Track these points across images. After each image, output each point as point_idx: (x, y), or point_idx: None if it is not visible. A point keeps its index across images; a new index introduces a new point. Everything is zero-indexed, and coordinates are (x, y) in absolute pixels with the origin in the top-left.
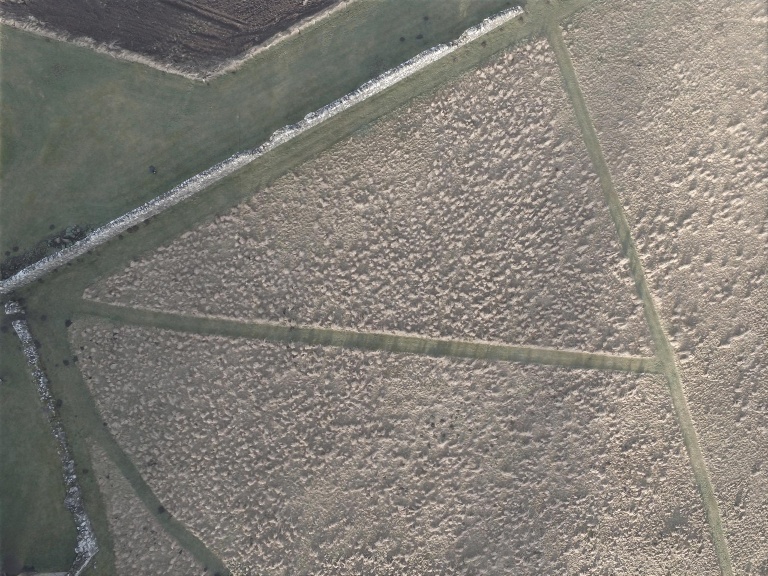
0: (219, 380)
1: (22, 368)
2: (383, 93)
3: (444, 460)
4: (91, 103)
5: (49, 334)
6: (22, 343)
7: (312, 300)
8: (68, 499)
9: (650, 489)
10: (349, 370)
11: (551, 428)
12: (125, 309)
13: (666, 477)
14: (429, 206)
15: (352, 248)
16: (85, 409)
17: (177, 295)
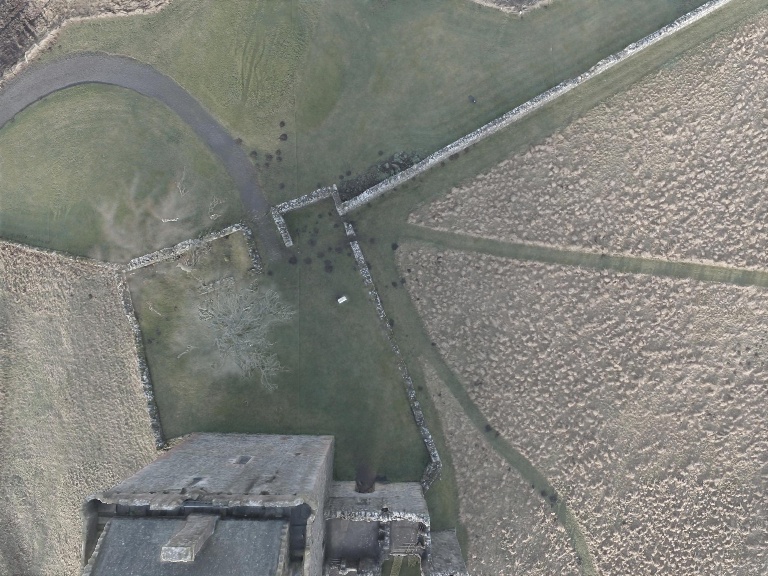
0: (538, 304)
1: (358, 287)
2: (687, 28)
3: (750, 387)
4: (413, 34)
5: (377, 256)
6: (358, 263)
7: (622, 229)
8: (418, 411)
9: None
10: (659, 297)
11: None
12: (447, 234)
13: None
14: (732, 139)
15: (660, 179)
16: (414, 329)
17: (495, 221)
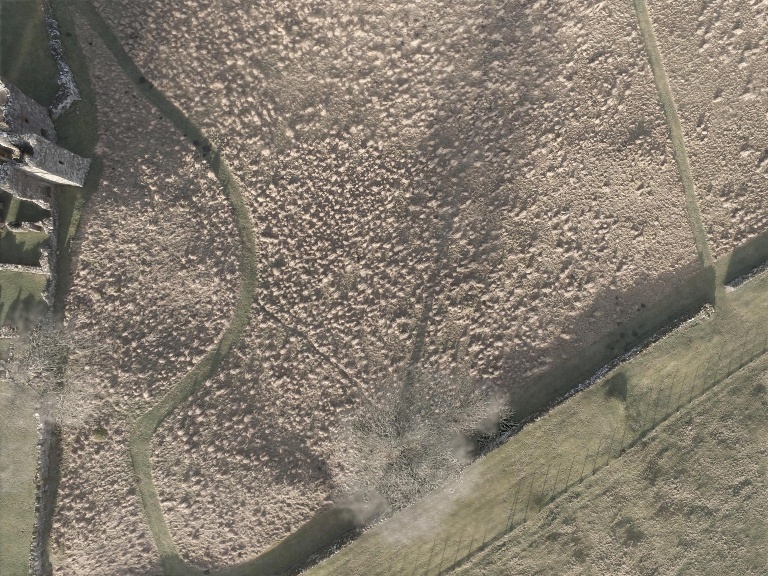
0: None
1: None
2: None
3: (417, 57)
4: None
5: None
6: None
7: None
8: (51, 42)
9: (615, 101)
10: None
11: (521, 33)
12: None
13: (631, 92)
14: None
15: None
16: None
17: None
